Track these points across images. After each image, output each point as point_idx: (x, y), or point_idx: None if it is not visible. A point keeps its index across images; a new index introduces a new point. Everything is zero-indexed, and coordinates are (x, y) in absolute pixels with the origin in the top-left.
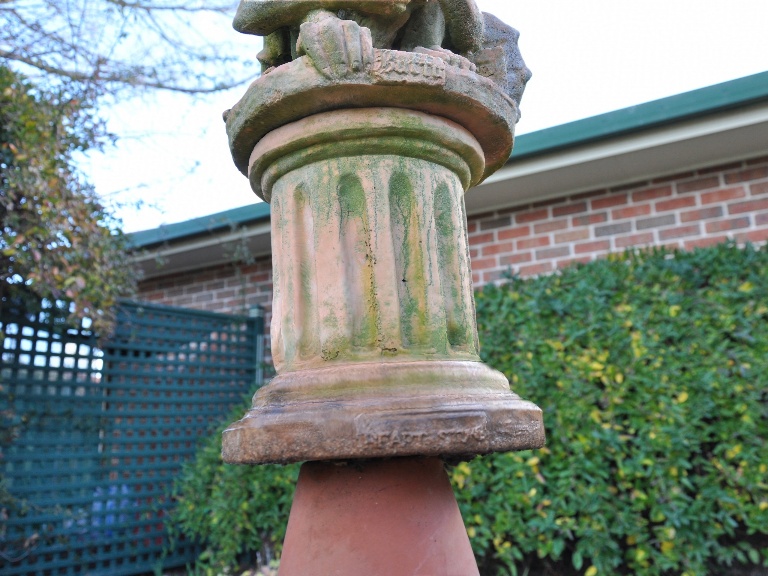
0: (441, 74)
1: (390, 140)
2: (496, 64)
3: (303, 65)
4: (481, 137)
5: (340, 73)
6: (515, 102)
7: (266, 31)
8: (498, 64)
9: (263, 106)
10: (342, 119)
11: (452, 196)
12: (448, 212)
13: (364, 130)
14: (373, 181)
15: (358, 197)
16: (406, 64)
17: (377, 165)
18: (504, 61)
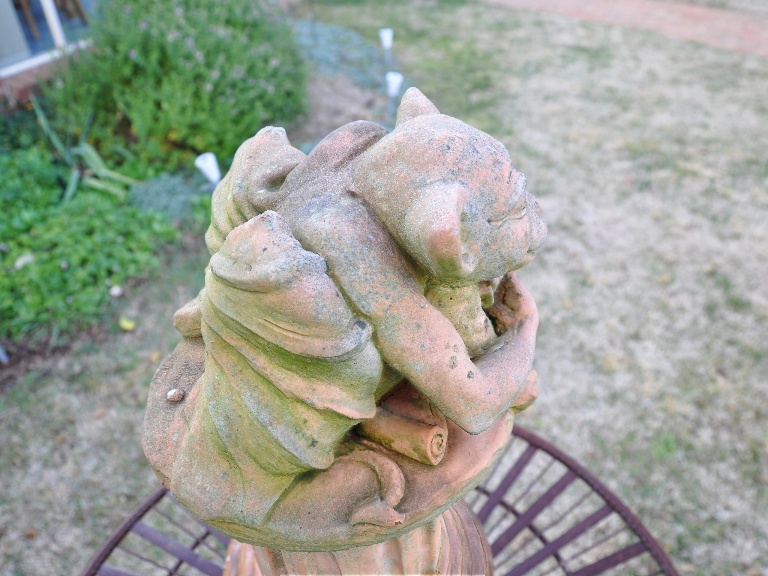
0: None
1: None
2: None
3: None
4: None
5: None
6: None
7: None
8: None
9: None
10: None
11: None
12: None
13: None
14: None
15: None
16: None
17: None
18: None
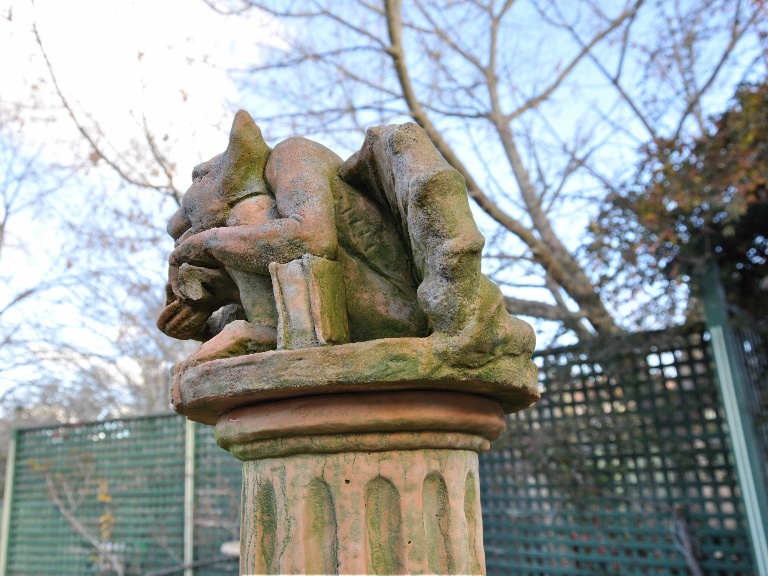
0: None
1: None
2: None
3: None
4: None
5: None
6: (434, 240)
7: None
8: None
9: None
10: None
11: (278, 496)
12: None
13: None
14: None
15: None
16: None
17: None
18: (283, 275)
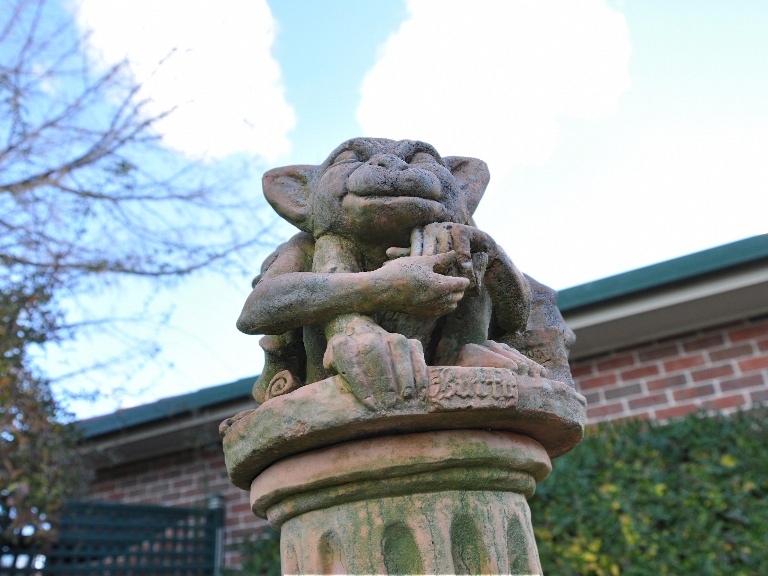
0: (513, 393)
1: (448, 474)
2: (552, 348)
3: (336, 391)
4: (545, 439)
5: (387, 403)
6: None
7: (280, 332)
8: (555, 348)
9: (280, 438)
10: (386, 453)
11: (525, 531)
12: (523, 556)
13: (416, 466)
14: (429, 532)
15: (409, 553)
16: (470, 385)
17: (432, 508)
18: None
